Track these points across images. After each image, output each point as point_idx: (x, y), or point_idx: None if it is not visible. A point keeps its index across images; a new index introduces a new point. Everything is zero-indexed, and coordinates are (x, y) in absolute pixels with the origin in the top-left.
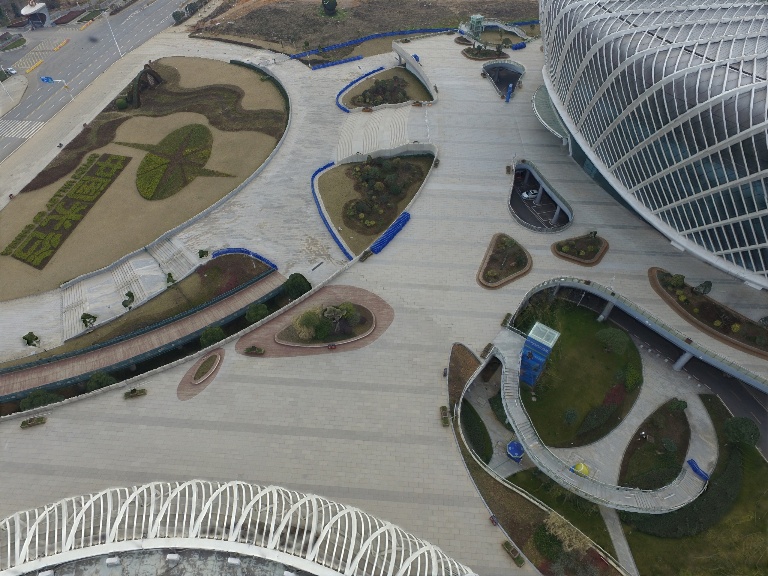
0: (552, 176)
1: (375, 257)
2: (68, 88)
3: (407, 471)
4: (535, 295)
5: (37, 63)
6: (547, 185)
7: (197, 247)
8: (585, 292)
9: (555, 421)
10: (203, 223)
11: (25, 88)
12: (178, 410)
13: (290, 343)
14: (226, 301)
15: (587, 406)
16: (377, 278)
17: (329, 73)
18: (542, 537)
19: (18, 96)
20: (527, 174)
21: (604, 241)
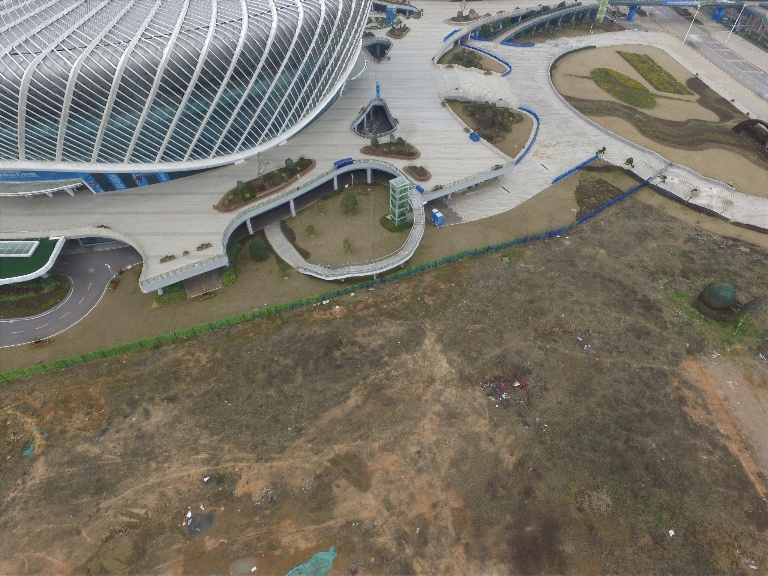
0: None
1: None
2: None
3: (431, 6)
4: None
5: None
6: None
7: None
8: None
9: None
10: None
11: None
12: None
13: None
14: None
15: None
16: None
17: (574, 154)
18: (398, 1)
19: None
20: None
21: None
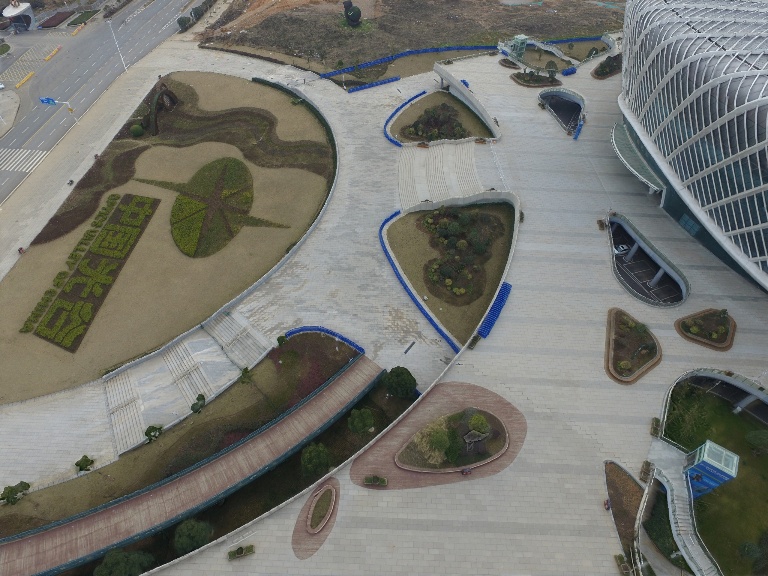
0: (649, 233)
1: (484, 342)
2: (72, 110)
3: None
4: (673, 389)
5: (27, 76)
6: (648, 245)
7: (264, 324)
8: (721, 381)
9: (725, 552)
10: (265, 291)
11: (17, 107)
12: (299, 574)
13: (416, 468)
14: (315, 400)
15: (755, 530)
16: (494, 371)
17: (368, 97)
18: None
19: (10, 117)
20: (614, 226)
21: (730, 318)
